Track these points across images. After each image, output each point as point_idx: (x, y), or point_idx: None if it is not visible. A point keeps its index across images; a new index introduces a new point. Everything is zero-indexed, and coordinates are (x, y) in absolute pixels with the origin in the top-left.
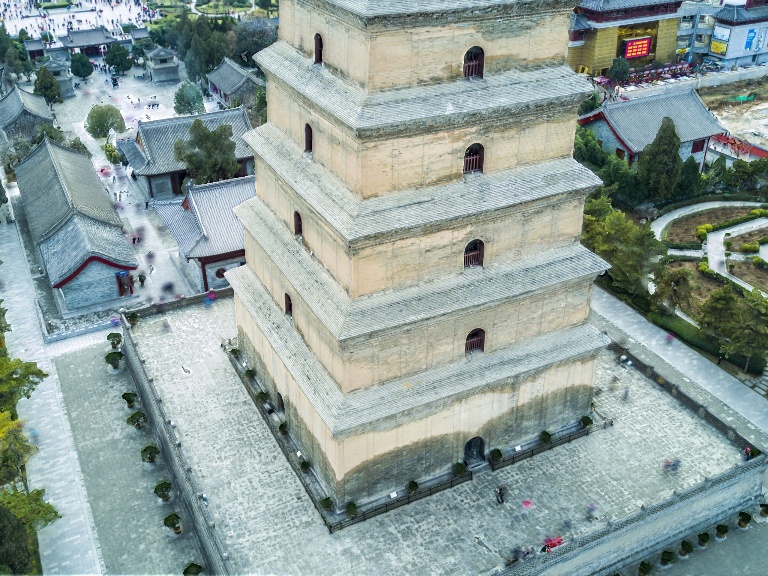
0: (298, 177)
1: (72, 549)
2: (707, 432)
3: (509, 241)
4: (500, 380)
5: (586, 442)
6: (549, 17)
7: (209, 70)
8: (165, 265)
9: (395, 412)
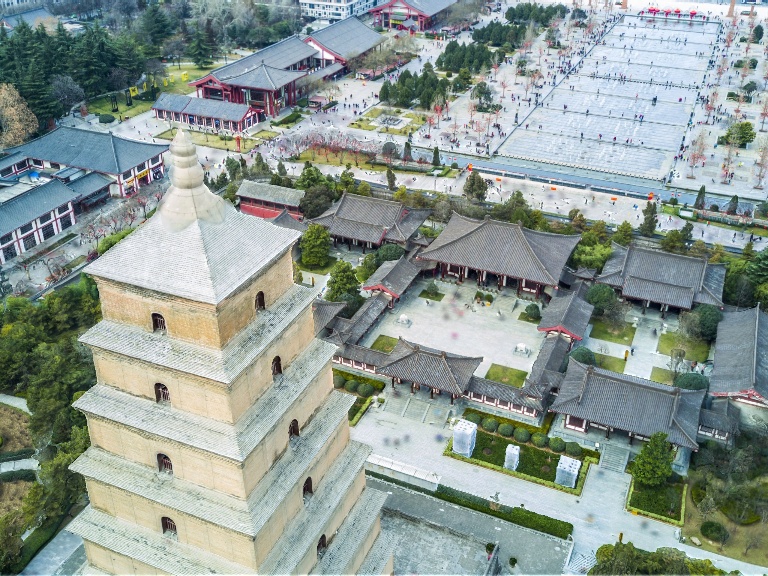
0: None
1: None
2: None
3: None
4: None
5: None
6: None
7: None
8: None
9: None
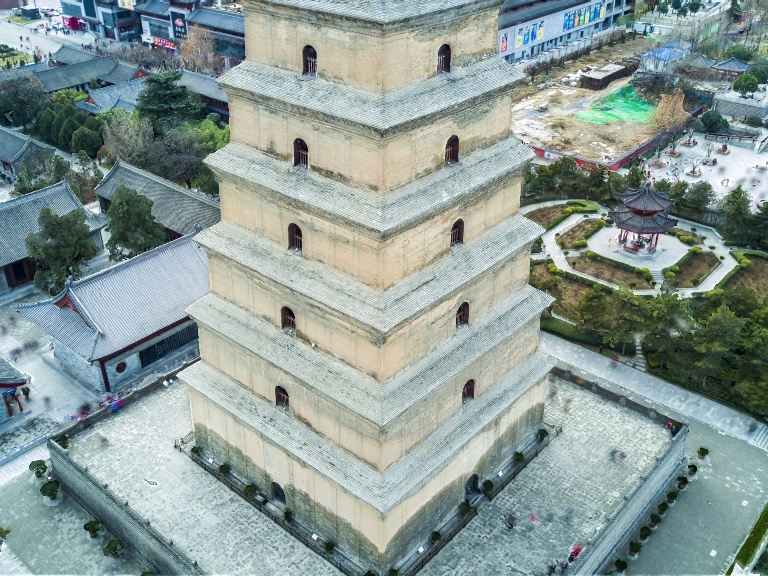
0: (292, 276)
1: None
2: (633, 417)
3: (485, 297)
4: None
5: (549, 452)
6: (499, 99)
7: None
8: (42, 370)
9: (425, 476)
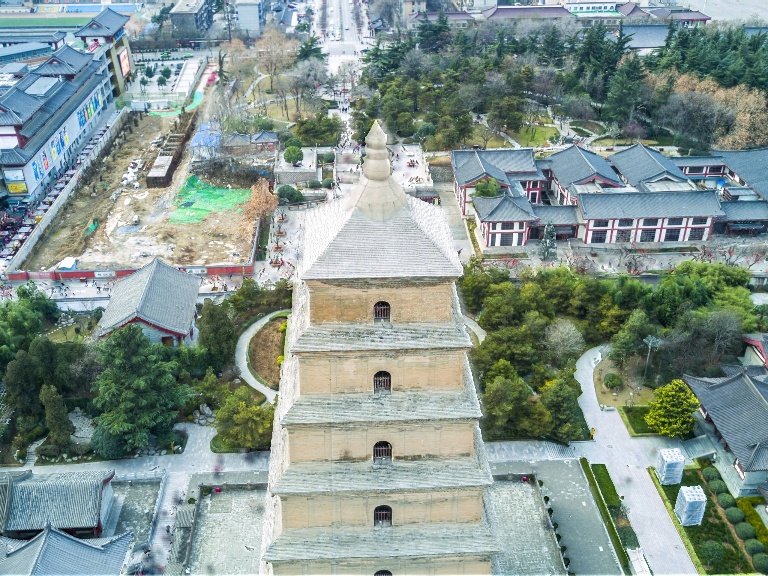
0: (395, 546)
1: None
2: (500, 486)
3: None
4: None
5: None
6: None
7: None
8: None
9: None
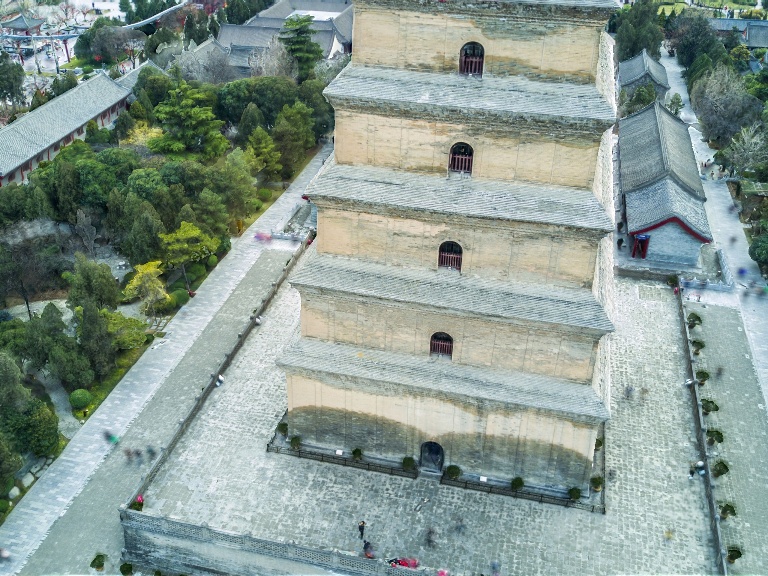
0: None
1: (148, 376)
2: None
3: (494, 257)
4: (458, 394)
5: (557, 512)
6: (571, 26)
7: (626, 59)
8: None
9: (335, 372)
